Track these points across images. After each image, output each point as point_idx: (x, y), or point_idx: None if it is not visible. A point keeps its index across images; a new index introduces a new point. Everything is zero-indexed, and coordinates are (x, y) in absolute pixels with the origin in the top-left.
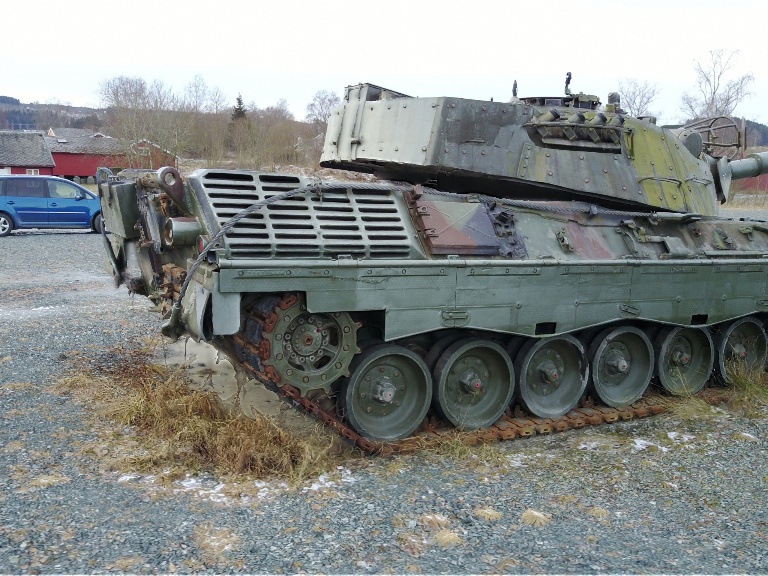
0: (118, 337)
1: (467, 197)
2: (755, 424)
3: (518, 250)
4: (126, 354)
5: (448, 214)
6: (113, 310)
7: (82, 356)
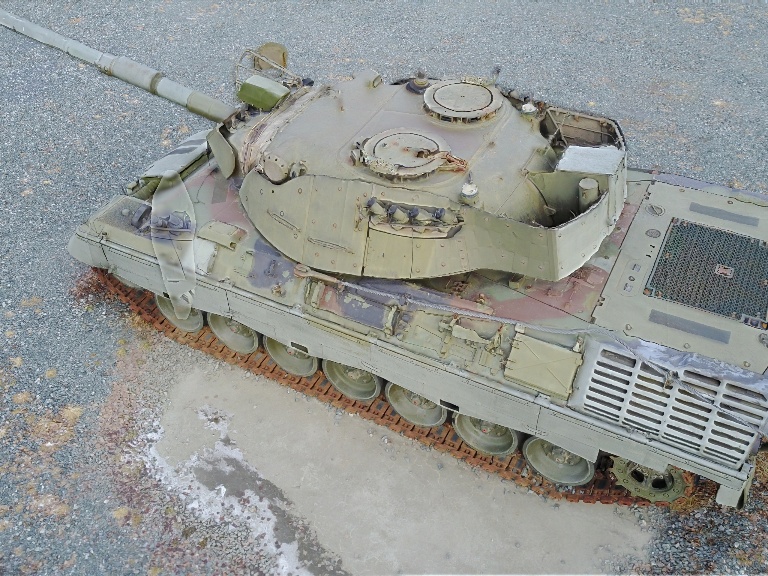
0: None
1: None
2: None
3: None
4: None
5: None
6: None
7: (740, 573)
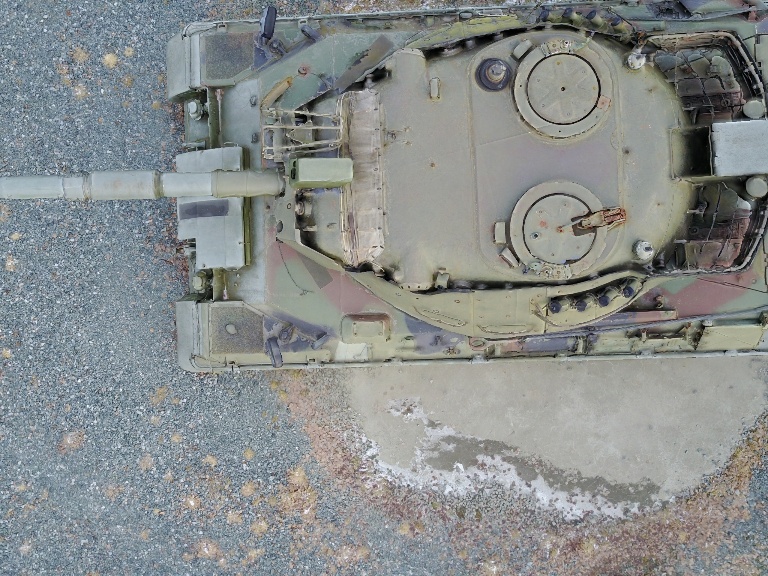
0: None
1: None
2: None
3: None
4: None
5: (724, 5)
6: None
7: None
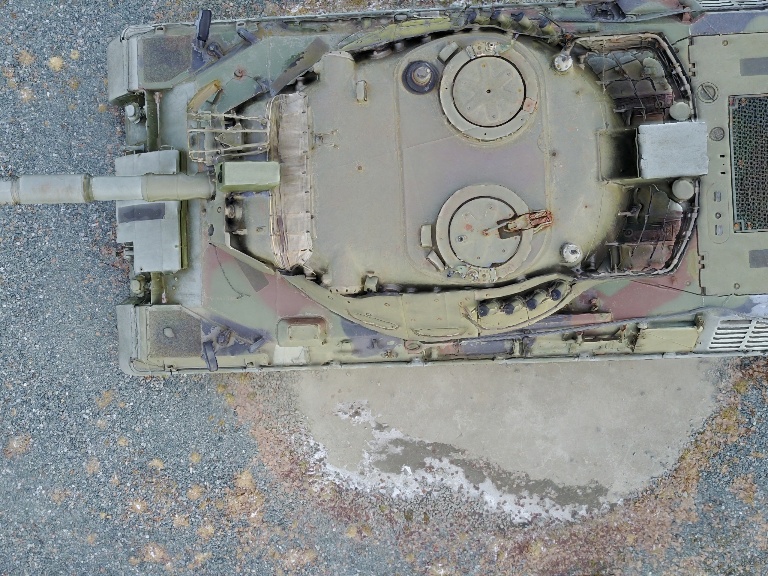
0: (763, 429)
1: (637, 19)
2: (400, 0)
3: (594, 8)
4: (763, 362)
5: None
6: (754, 568)
7: None
